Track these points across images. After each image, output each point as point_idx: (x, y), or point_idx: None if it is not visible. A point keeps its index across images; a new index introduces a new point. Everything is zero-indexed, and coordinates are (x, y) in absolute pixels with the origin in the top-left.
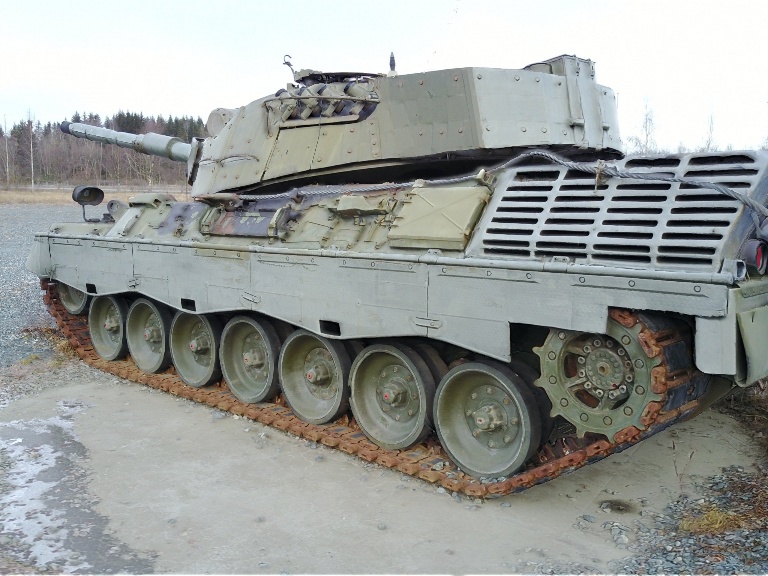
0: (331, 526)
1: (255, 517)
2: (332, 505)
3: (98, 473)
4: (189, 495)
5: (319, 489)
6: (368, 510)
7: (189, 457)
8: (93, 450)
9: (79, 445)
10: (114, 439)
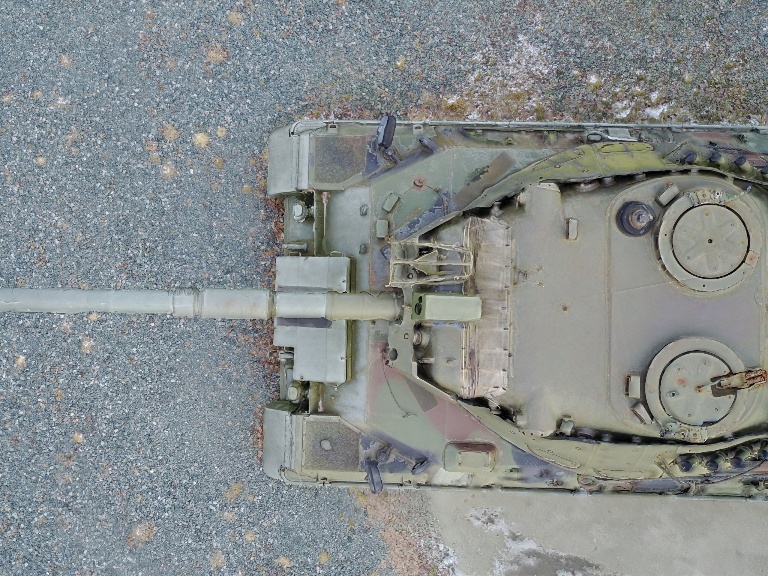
0: (767, 534)
1: (734, 552)
2: (751, 517)
3: (625, 574)
4: (688, 558)
5: (731, 507)
6: (767, 509)
7: (640, 525)
8: (588, 557)
9: (573, 558)
10: (579, 538)
